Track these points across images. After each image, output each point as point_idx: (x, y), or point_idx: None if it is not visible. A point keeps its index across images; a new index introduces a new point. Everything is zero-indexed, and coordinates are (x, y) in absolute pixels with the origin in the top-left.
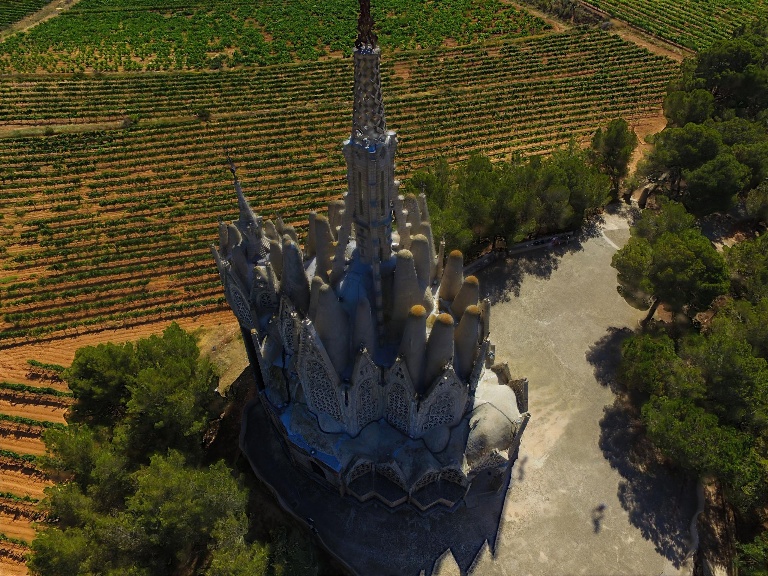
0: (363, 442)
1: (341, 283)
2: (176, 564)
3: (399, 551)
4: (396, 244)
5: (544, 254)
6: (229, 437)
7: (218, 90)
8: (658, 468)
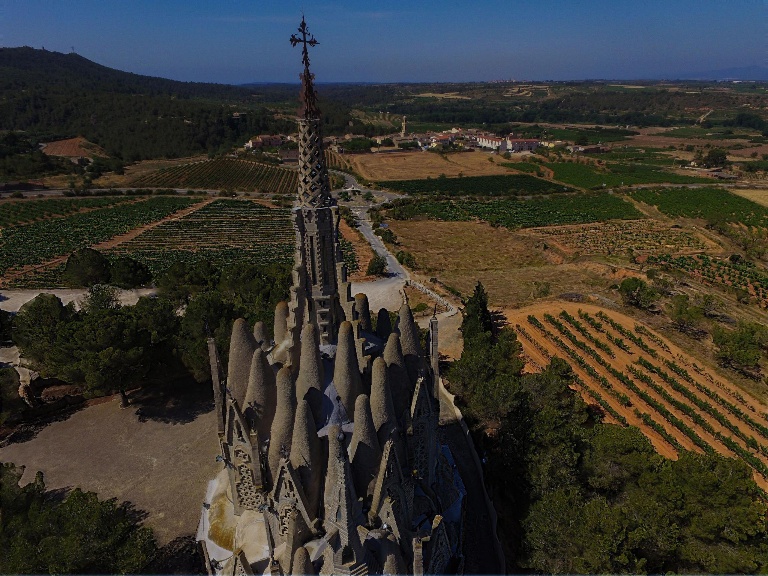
0: None
1: (372, 345)
2: None
3: None
4: None
5: None
6: None
7: None
8: None
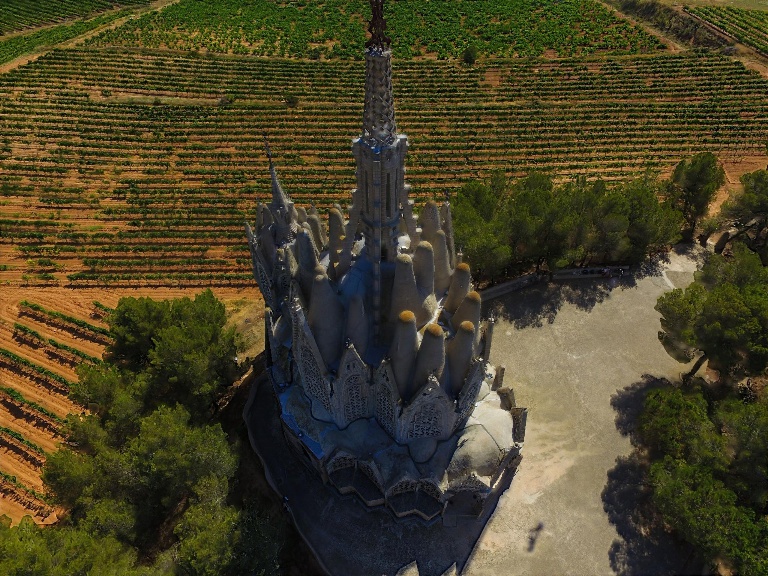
0: (349, 436)
1: (344, 277)
2: (161, 509)
3: (366, 550)
4: (405, 248)
5: (591, 285)
6: (240, 405)
7: (311, 79)
8: (663, 535)
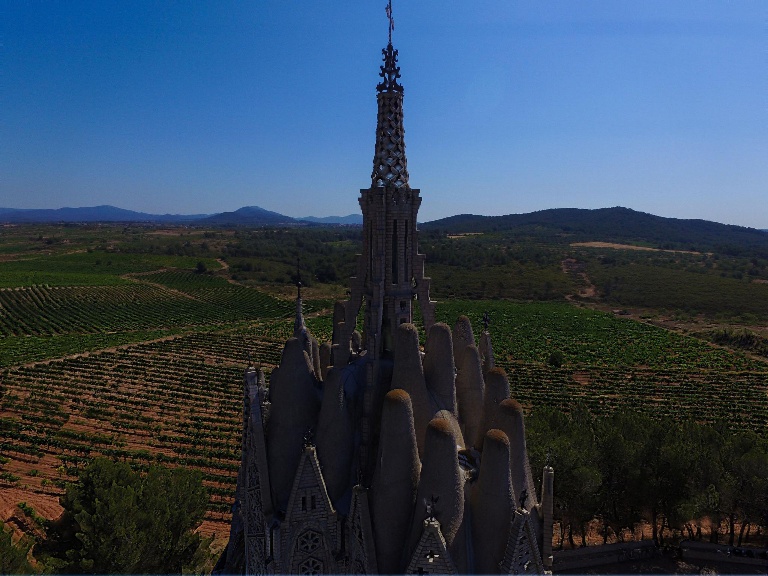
0: None
1: None
2: None
3: None
4: None
5: (755, 575)
6: None
7: None
8: None
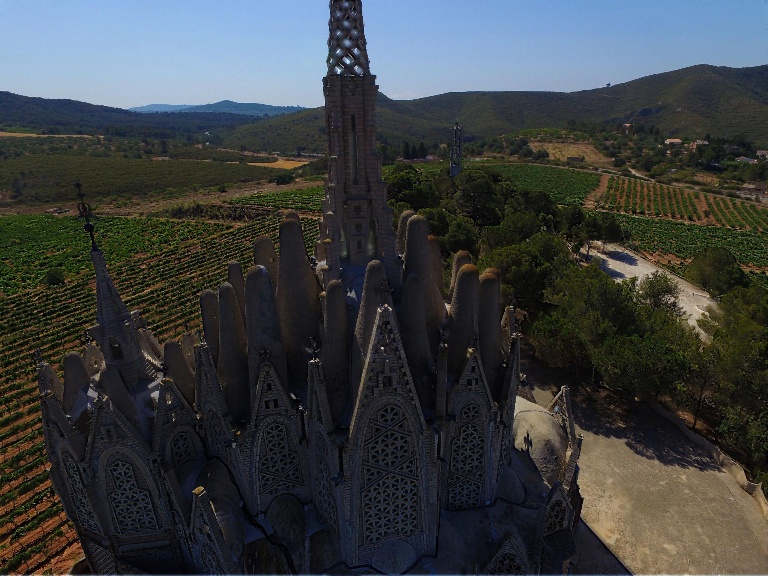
0: (450, 552)
1: (352, 294)
2: None
3: None
4: None
5: None
6: None
7: None
8: (628, 418)
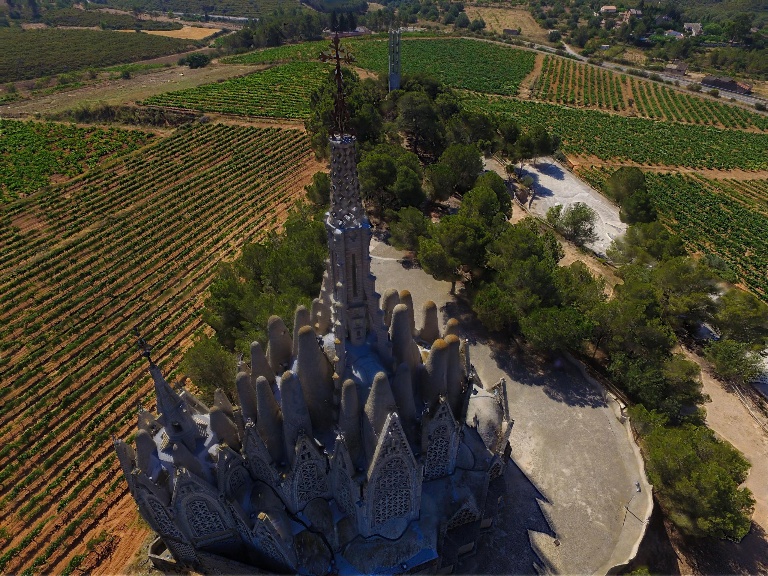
0: (428, 514)
1: (358, 375)
2: None
3: (509, 572)
4: None
5: None
6: None
7: None
8: (546, 365)
